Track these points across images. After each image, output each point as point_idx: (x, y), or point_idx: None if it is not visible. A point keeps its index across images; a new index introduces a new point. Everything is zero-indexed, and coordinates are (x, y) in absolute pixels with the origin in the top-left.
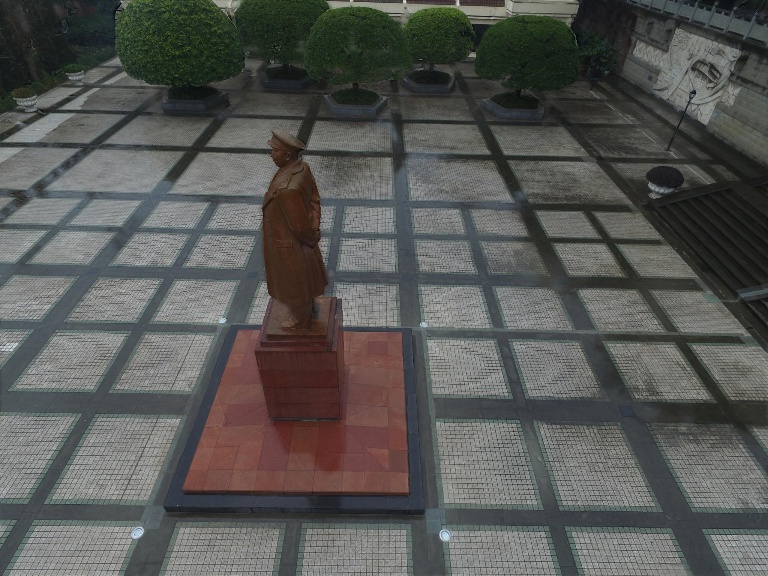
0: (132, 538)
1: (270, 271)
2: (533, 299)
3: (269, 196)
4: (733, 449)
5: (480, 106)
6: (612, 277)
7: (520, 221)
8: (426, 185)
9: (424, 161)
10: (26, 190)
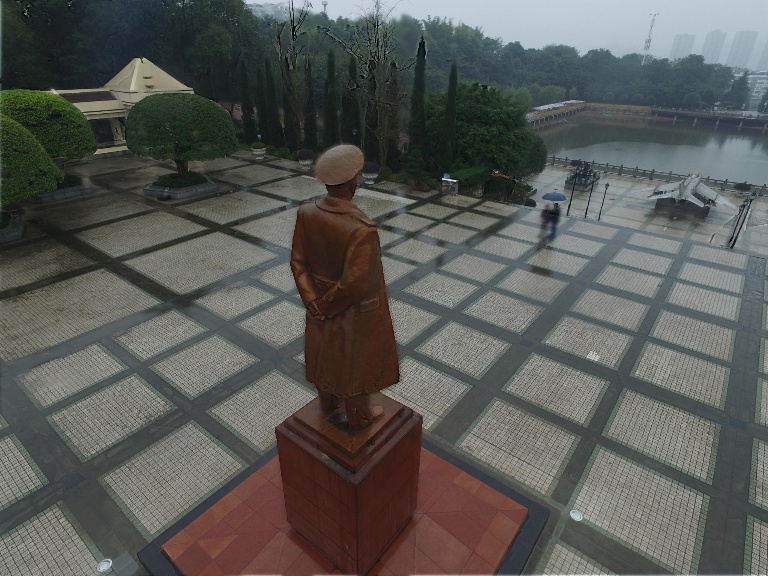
0: None
1: None
2: None
3: None
4: None
5: None
6: None
7: None
8: None
9: None
10: None
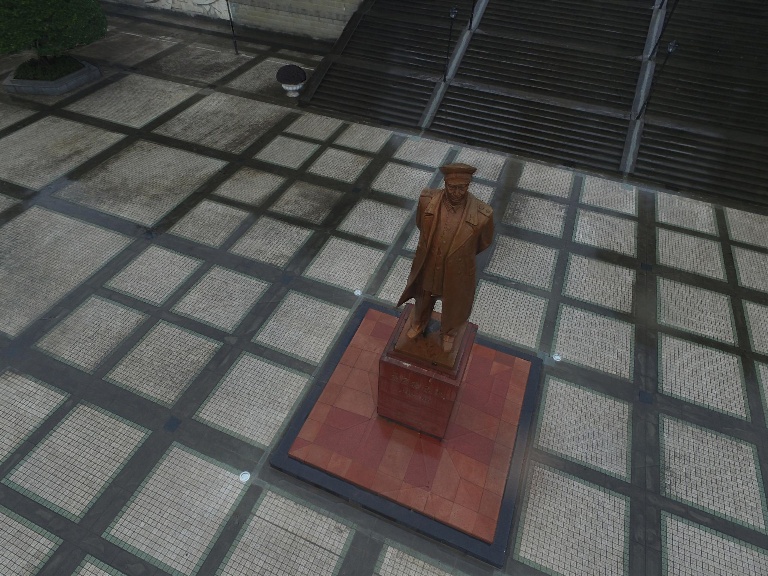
0: None
1: (450, 309)
2: (367, 215)
3: (468, 234)
4: (528, 201)
5: (8, 93)
6: (368, 165)
7: (261, 173)
8: (133, 203)
9: (79, 184)
10: None
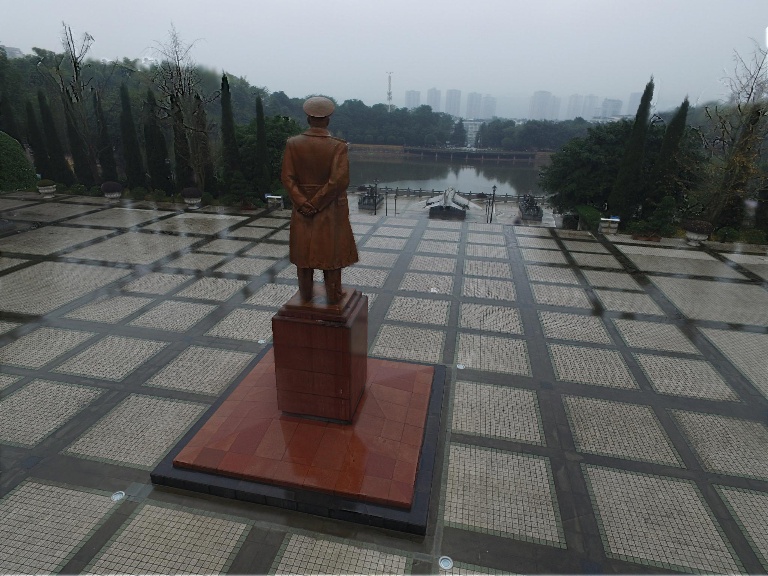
0: (260, 340)
1: None
2: None
3: None
4: None
5: None
6: None
7: None
8: None
9: None
10: (640, 270)
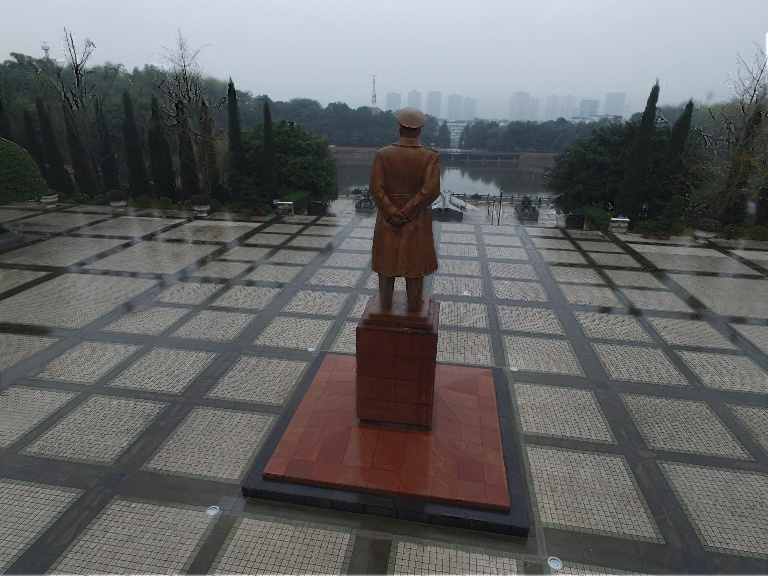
0: (309, 348)
1: None
2: None
3: None
4: None
5: None
6: None
7: None
8: None
9: None
10: (658, 268)
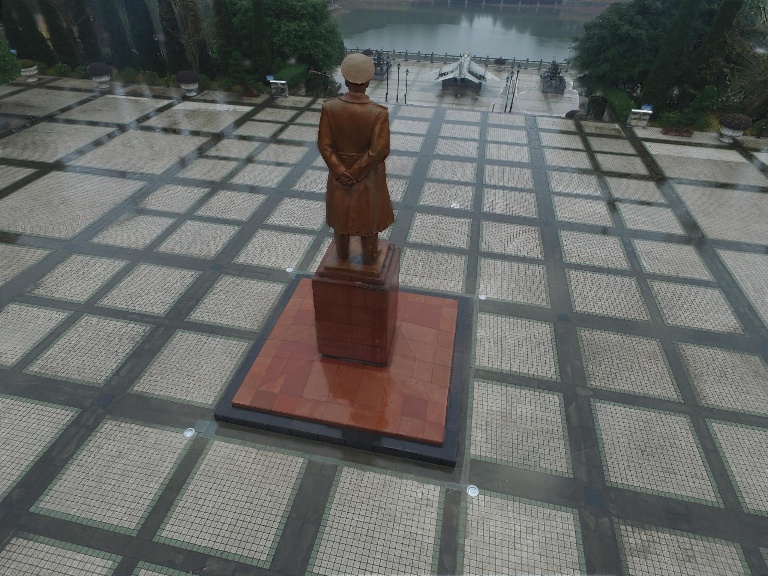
0: (287, 268)
1: None
2: None
3: None
4: None
5: None
6: None
7: None
8: None
9: None
10: (665, 177)
